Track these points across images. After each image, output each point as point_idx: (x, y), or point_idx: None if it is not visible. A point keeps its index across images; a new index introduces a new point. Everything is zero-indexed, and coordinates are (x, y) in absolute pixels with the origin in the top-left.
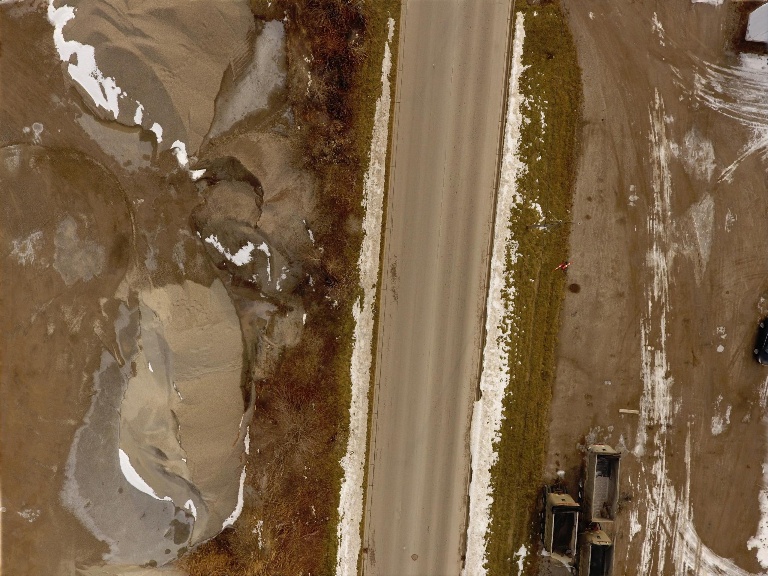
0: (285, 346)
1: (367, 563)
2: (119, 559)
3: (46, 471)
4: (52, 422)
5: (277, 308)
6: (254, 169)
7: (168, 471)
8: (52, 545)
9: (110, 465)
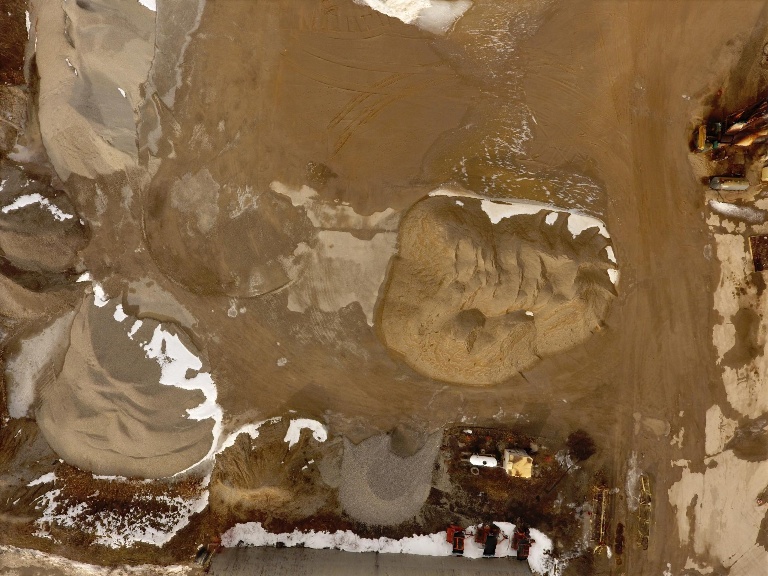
0: None
1: None
2: None
3: None
4: (221, 35)
5: (7, 156)
6: (6, 280)
7: None
8: None
9: None
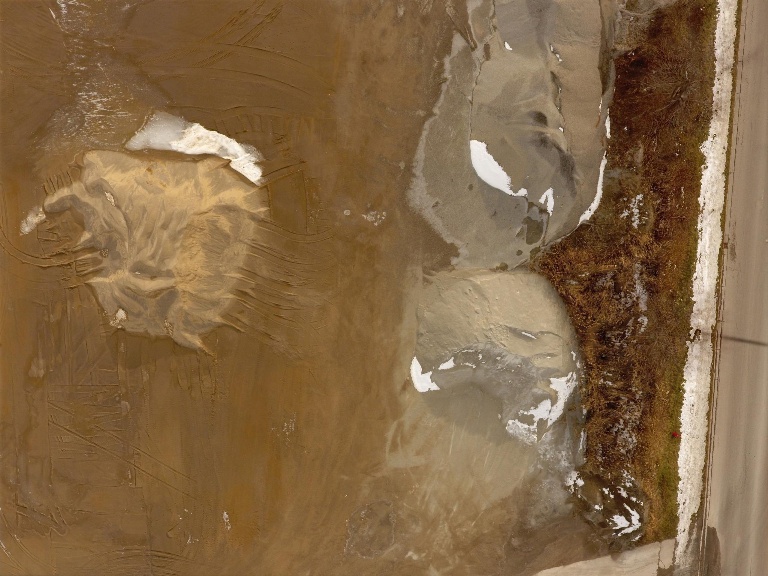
0: (660, 8)
1: (727, 259)
2: (468, 263)
3: (393, 168)
4: (400, 113)
5: None
6: None
7: (549, 138)
8: (398, 249)
9: (460, 159)
